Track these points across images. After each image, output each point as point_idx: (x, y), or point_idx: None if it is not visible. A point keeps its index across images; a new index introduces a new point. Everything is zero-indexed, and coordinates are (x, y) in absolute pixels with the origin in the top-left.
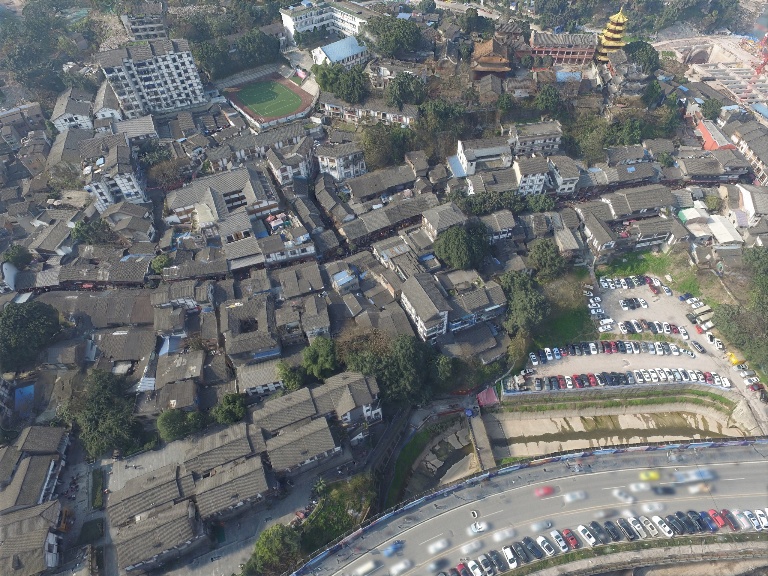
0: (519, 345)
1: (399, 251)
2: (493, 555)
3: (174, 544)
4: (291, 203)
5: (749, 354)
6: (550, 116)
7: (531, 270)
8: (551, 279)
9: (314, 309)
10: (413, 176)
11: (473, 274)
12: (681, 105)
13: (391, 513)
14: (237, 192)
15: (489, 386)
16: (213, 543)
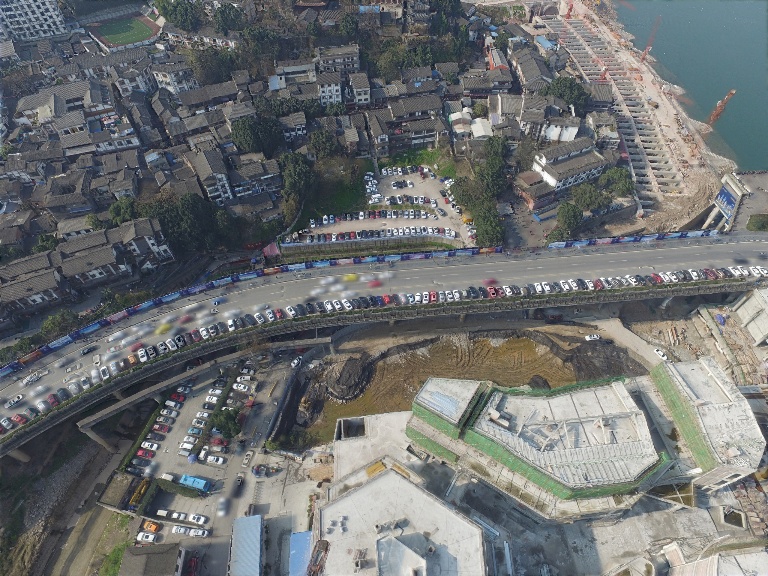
0: (289, 205)
1: (204, 140)
2: (219, 324)
3: None
4: (128, 110)
5: (471, 212)
6: (356, 42)
7: (315, 156)
8: (322, 158)
9: (122, 177)
10: (235, 89)
11: (260, 155)
12: (481, 38)
13: (150, 301)
14: (80, 100)
15: (273, 242)
16: (18, 329)
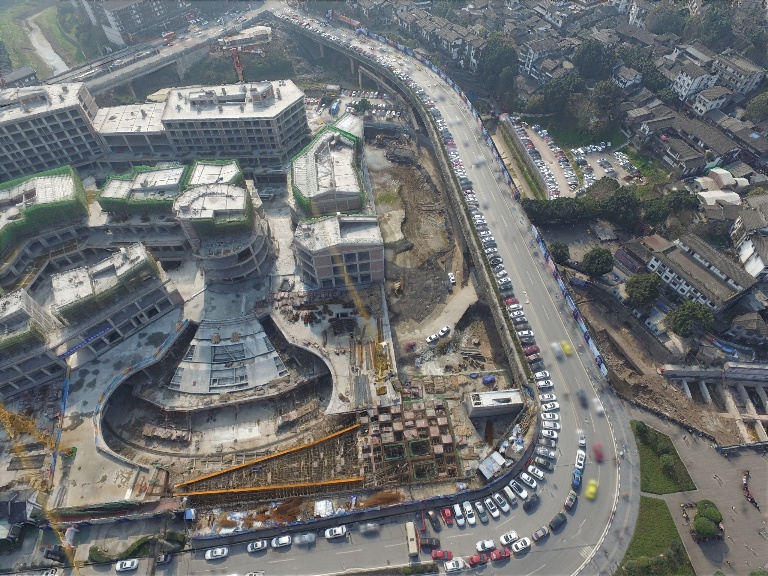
0: (533, 98)
1: None
2: (420, 88)
3: (407, 21)
4: None
5: None
6: None
7: None
8: None
9: None
10: (651, 42)
11: None
12: None
13: (429, 62)
14: None
15: None
16: None
